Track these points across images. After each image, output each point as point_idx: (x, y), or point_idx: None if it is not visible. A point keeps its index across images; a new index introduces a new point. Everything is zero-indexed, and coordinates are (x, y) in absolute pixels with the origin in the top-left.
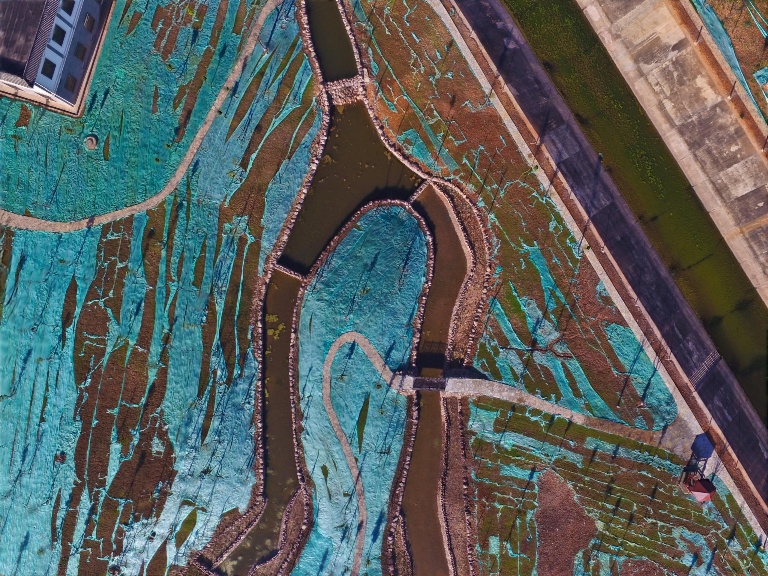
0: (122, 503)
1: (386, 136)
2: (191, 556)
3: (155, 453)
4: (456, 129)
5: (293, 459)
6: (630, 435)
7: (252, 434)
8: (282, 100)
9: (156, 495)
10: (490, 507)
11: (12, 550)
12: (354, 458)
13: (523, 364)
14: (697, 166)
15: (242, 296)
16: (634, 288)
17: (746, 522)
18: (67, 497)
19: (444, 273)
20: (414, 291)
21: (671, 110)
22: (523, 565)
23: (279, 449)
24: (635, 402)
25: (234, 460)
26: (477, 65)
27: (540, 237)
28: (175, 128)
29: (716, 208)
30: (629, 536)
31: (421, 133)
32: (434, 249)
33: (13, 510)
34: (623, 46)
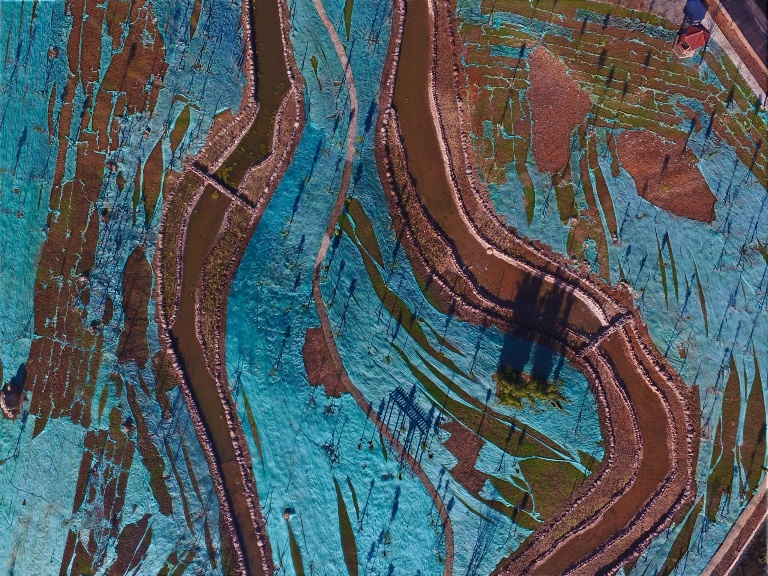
0: (116, 95)
1: None
2: (187, 161)
3: (146, 45)
4: None
5: (283, 61)
6: (620, 2)
7: (241, 35)
8: None
9: (149, 87)
10: (482, 91)
11: (11, 146)
12: (342, 46)
13: None
14: None
15: None
16: None
17: (744, 83)
18: (62, 91)
19: None
20: None
21: None
22: (518, 146)
23: (269, 54)
24: None
25: (224, 58)
26: None
27: None
28: None
29: None
30: (624, 107)
31: None
32: None
33: (10, 106)
34: None
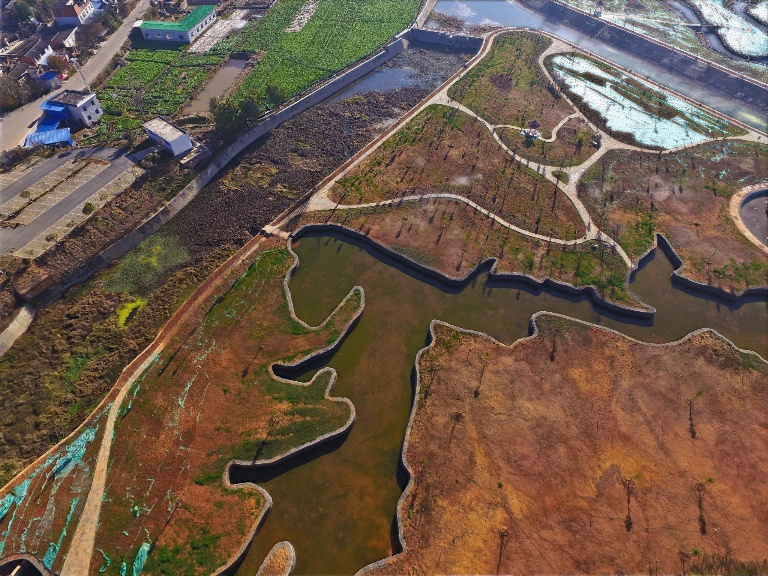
0: None
1: None
2: None
3: None
4: None
5: None
6: None
7: (762, 19)
8: None
9: None
10: None
11: None
12: None
13: None
14: None
15: None
16: None
17: None
18: None
19: None
20: None
21: None
22: None
23: None
24: None
25: None
26: None
27: None
28: None
29: None
30: None
31: (762, 68)
32: None
33: None
34: None
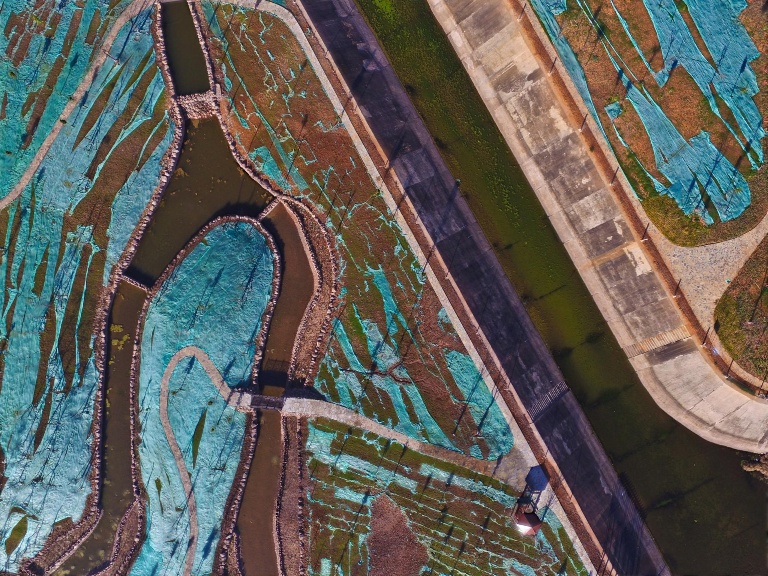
0: None
1: (238, 152)
2: (23, 563)
3: None
4: (307, 148)
5: (130, 471)
6: (465, 464)
7: (89, 444)
8: (132, 112)
9: None
10: (323, 529)
11: None
12: (188, 473)
13: (362, 387)
14: (552, 196)
15: (85, 305)
16: (476, 316)
17: (577, 557)
18: None
19: (291, 292)
20: (258, 308)
21: (528, 139)
22: None
23: (118, 460)
24: (472, 431)
25: (68, 469)
26: (330, 86)
27: (385, 260)
28: (22, 135)
29: (570, 239)
30: (460, 565)
31: (272, 151)
32: (281, 267)
33: None
34: (484, 73)
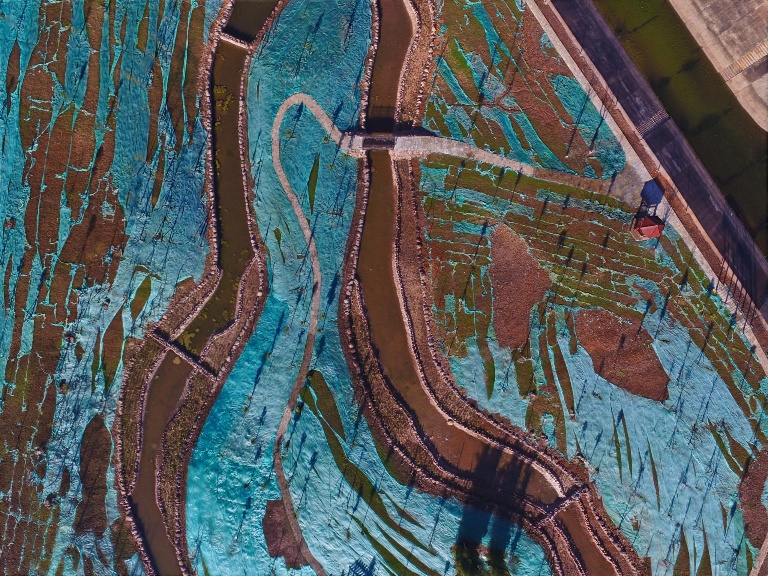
0: (74, 268)
1: None
2: (148, 328)
3: (106, 217)
4: None
5: (247, 229)
6: (580, 184)
7: (204, 203)
8: None
9: (108, 259)
10: (444, 265)
11: None
12: (306, 219)
13: (471, 119)
14: None
15: (188, 63)
16: (578, 39)
17: (698, 266)
18: (19, 263)
19: (390, 37)
20: (360, 53)
21: None
22: (479, 321)
23: (232, 220)
24: (583, 152)
25: (186, 227)
26: None
27: None
28: None
29: None
30: (583, 286)
31: None
32: (379, 13)
33: None
34: None
